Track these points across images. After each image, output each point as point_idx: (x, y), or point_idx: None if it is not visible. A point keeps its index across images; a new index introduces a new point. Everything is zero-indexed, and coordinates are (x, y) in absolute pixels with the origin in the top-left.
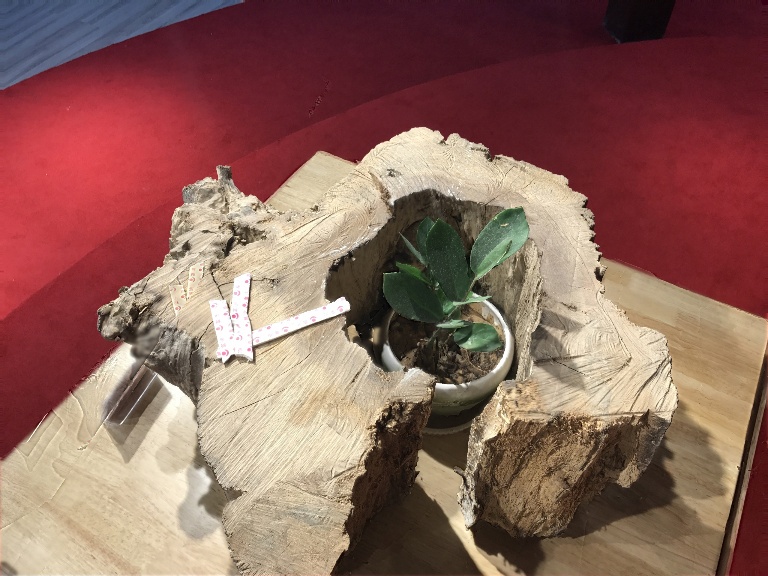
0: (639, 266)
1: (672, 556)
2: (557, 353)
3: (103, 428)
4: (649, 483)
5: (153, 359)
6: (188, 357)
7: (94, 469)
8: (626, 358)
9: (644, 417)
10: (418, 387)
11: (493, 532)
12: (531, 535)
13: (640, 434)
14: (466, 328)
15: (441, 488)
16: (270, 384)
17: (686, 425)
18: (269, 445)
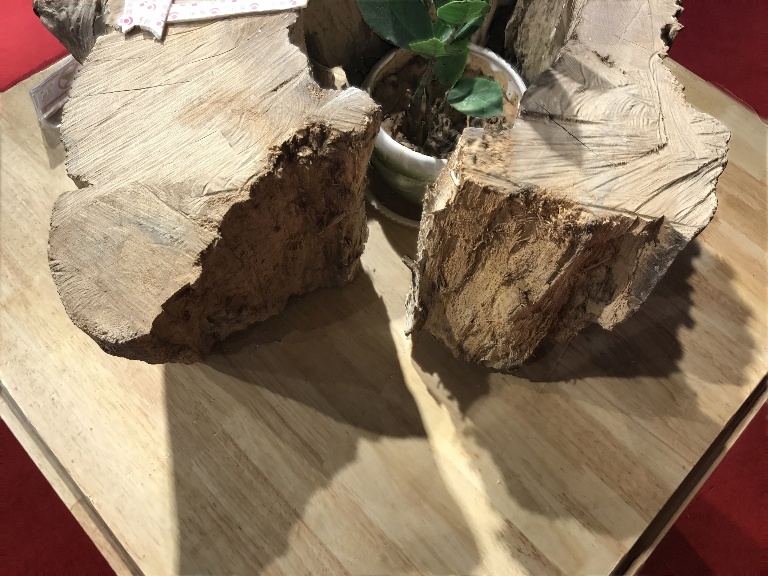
0: (742, 98)
1: (645, 434)
2: (559, 109)
3: (38, 126)
4: (650, 348)
5: (52, 19)
6: (91, 23)
7: (16, 166)
8: (658, 142)
9: (654, 226)
10: (352, 112)
11: (437, 349)
12: (477, 361)
13: (642, 253)
14: (467, 84)
15: (394, 286)
16: (172, 71)
17: (725, 296)
18: (142, 140)
